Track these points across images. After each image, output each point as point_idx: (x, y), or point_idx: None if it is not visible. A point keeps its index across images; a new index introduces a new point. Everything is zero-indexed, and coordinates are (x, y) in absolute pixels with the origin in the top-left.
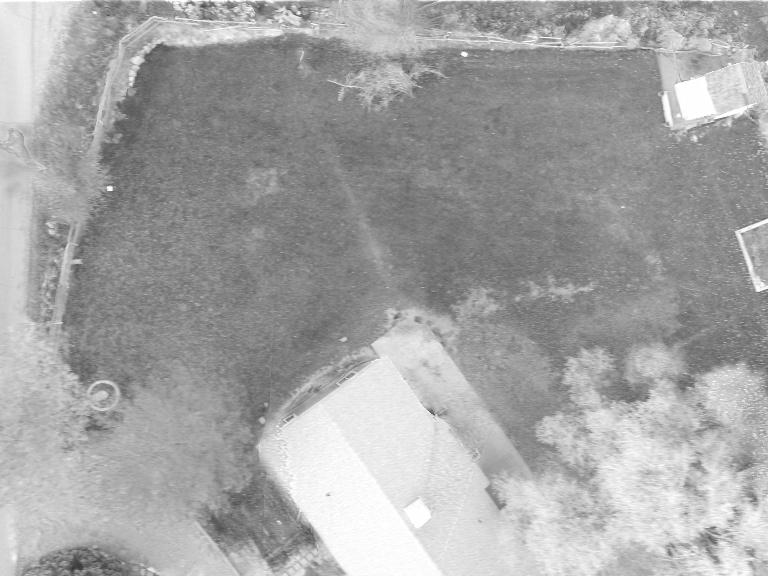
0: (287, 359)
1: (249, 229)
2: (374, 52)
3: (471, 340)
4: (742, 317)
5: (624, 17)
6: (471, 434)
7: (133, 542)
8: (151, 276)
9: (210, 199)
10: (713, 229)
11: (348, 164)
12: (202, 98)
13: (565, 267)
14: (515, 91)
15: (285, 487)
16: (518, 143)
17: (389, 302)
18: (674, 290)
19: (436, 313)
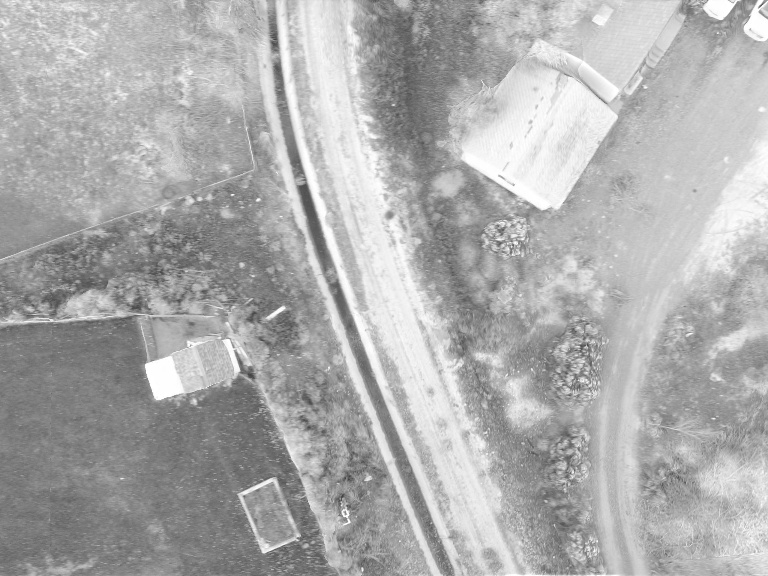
0: None
1: None
2: None
3: None
4: None
5: (106, 291)
6: None
7: None
8: None
9: None
10: (216, 493)
11: None
12: None
13: (62, 546)
14: (7, 369)
15: None
16: (11, 423)
17: None
18: (177, 559)
19: None
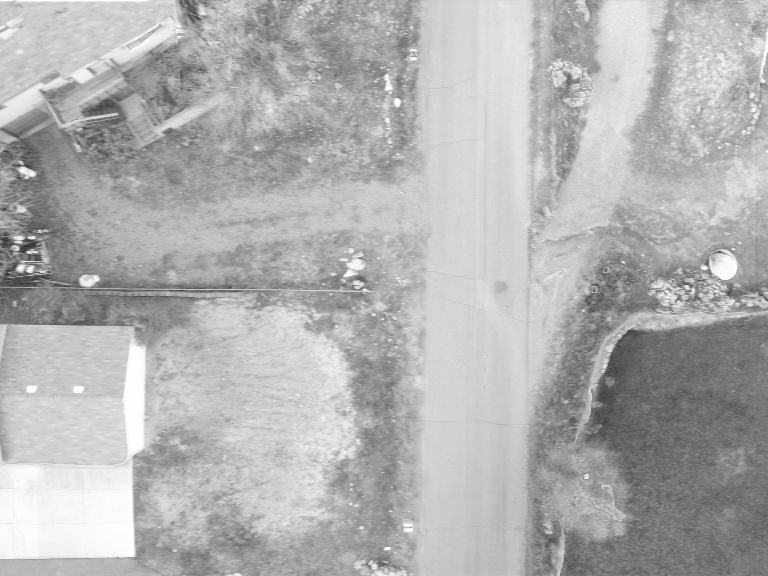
0: None
1: (720, 509)
2: None
3: None
4: None
5: None
6: None
7: None
8: (628, 561)
9: (682, 481)
10: None
11: None
12: (671, 381)
13: None
14: None
15: None
16: None
17: None
18: None
19: None
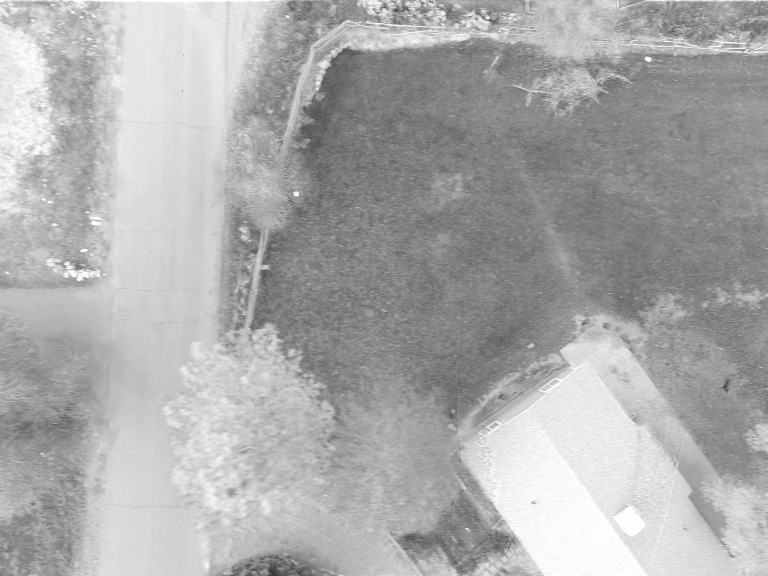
0: (474, 365)
1: (435, 235)
2: (559, 57)
3: (659, 346)
4: None
5: None
6: (664, 441)
7: (323, 550)
8: (337, 282)
9: (396, 204)
10: None
11: (533, 169)
12: (387, 103)
13: (751, 273)
14: (699, 96)
15: (488, 495)
16: (703, 149)
17: (577, 308)
18: None
19: (624, 319)
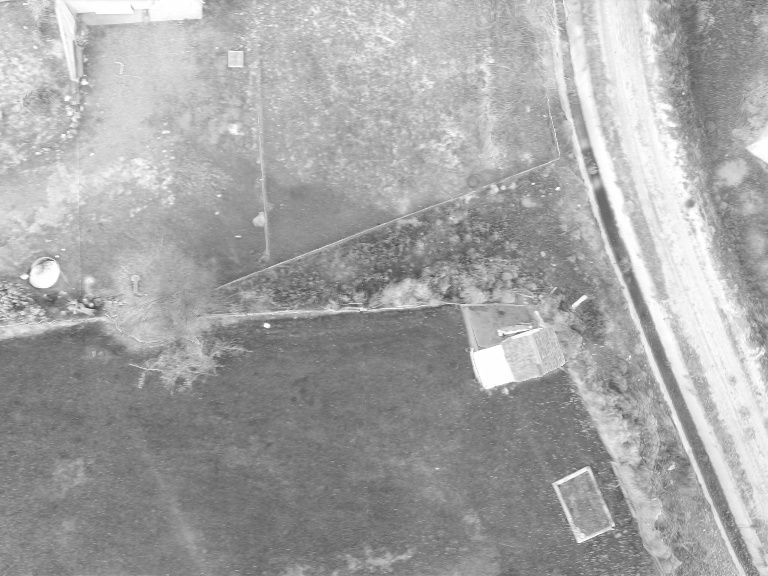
0: None
1: (59, 523)
2: None
3: None
4: (565, 569)
5: (423, 280)
6: None
7: None
8: None
9: (17, 495)
10: (530, 482)
11: (155, 448)
12: (2, 393)
13: (381, 537)
14: (321, 359)
15: None
16: (326, 413)
17: None
18: (494, 549)
19: None
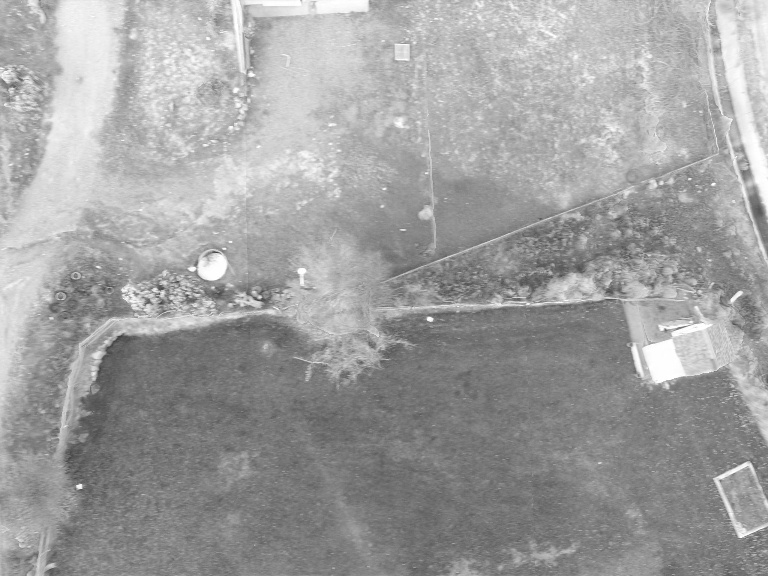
0: None
1: (224, 516)
2: None
3: None
4: (726, 564)
5: (588, 274)
6: None
7: None
8: (127, 572)
9: (182, 488)
10: (691, 477)
11: (320, 441)
12: (167, 386)
13: (546, 531)
14: (484, 353)
15: None
16: (490, 407)
17: None
18: (656, 543)
19: None
